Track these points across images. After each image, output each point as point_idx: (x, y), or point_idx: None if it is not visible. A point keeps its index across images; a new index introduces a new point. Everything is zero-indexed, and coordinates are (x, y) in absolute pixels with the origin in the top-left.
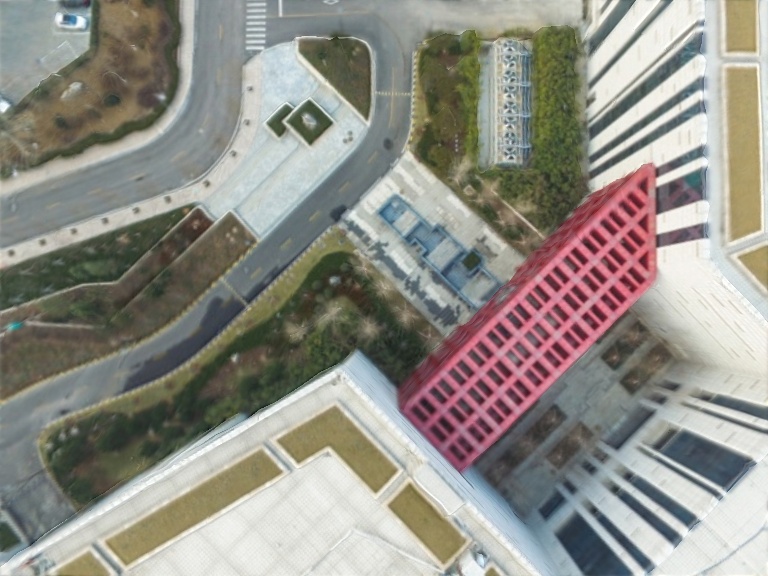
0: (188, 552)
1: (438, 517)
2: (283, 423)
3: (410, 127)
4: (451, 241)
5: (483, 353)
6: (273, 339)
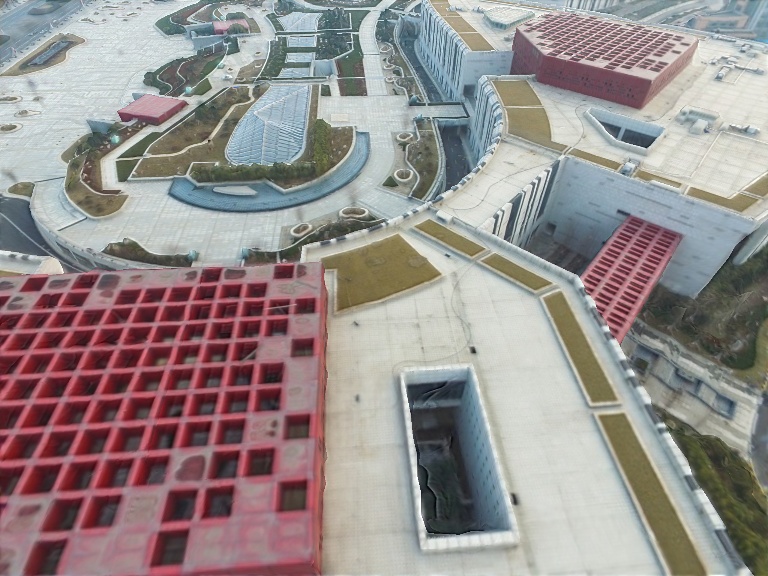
0: (760, 168)
1: (656, 180)
2: (761, 206)
3: (761, 486)
4: (664, 380)
5: (652, 260)
6: (750, 307)
